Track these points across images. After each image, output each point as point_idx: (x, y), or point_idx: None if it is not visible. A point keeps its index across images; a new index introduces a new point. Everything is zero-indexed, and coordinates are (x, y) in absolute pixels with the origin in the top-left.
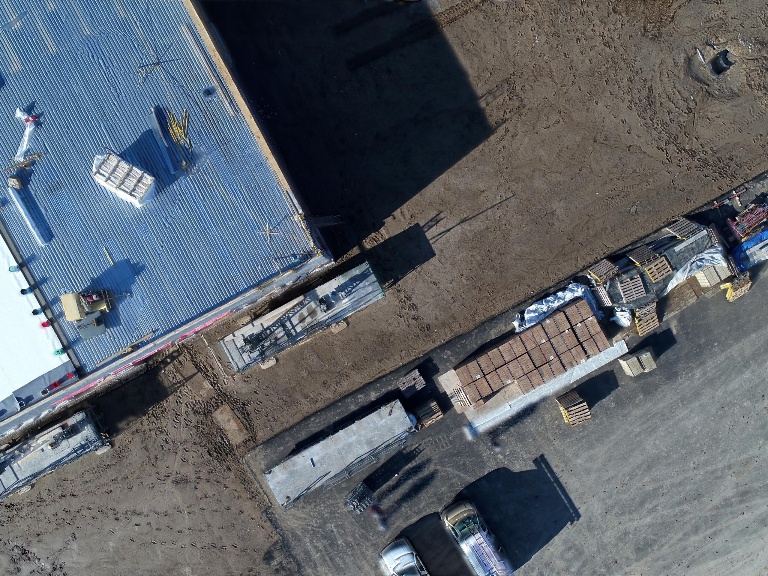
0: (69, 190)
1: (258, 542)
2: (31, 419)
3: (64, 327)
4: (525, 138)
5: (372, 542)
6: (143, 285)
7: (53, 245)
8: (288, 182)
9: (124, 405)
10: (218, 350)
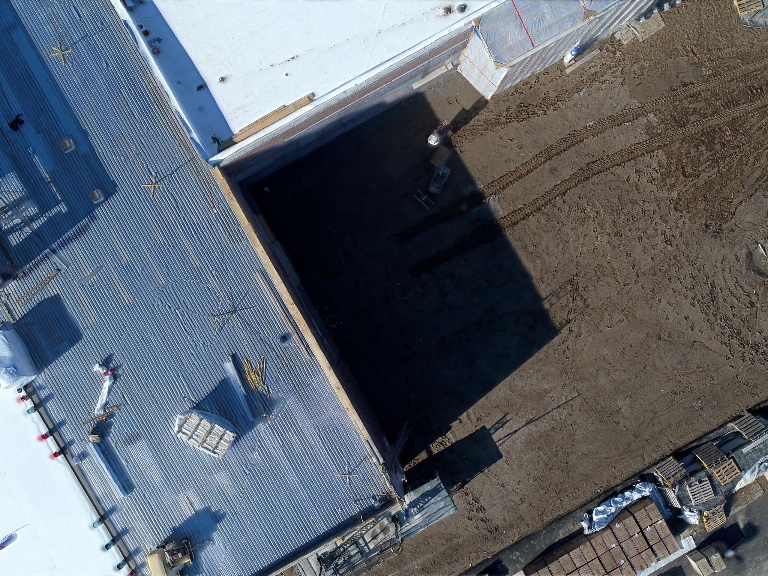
0: (149, 441)
1: None
2: None
3: None
4: (589, 338)
5: None
6: (225, 532)
7: (135, 496)
8: (368, 432)
9: None
10: None
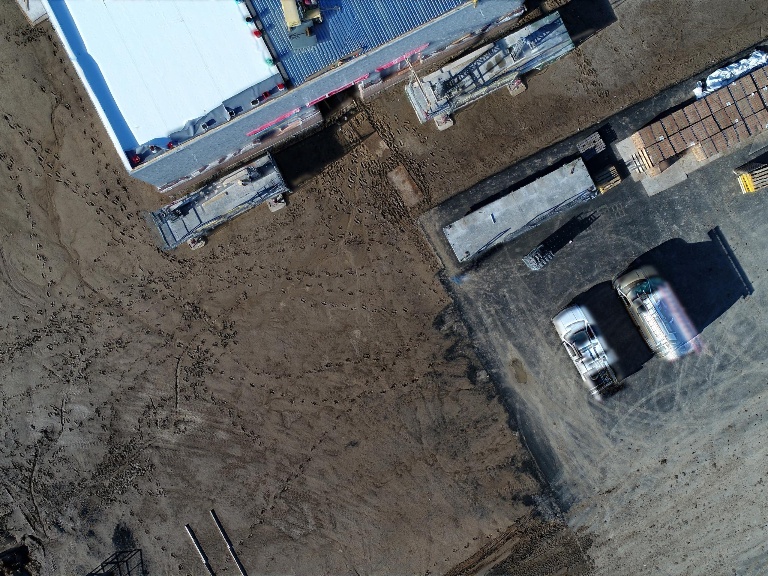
0: None
1: (429, 306)
2: (216, 161)
3: (274, 40)
4: None
5: (544, 308)
6: (353, 0)
7: None
8: None
9: (300, 163)
10: (396, 110)
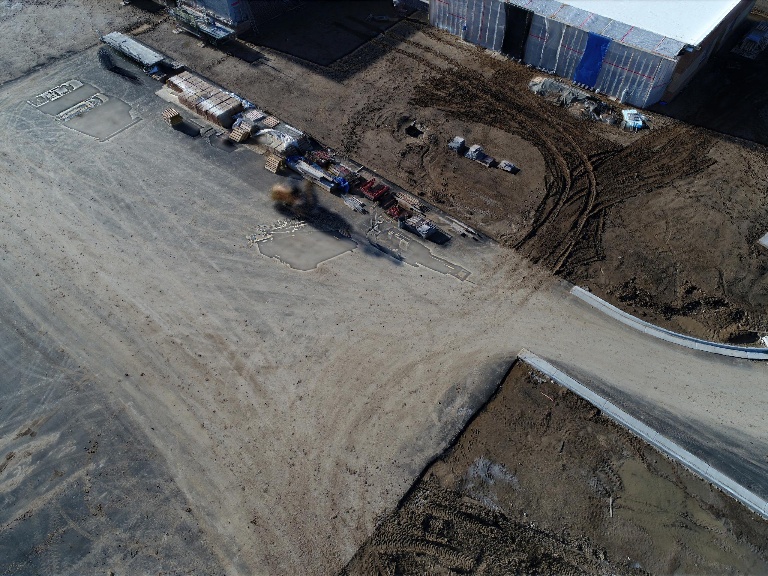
0: None
1: None
2: None
3: None
4: (328, 76)
5: (80, 76)
6: None
7: None
8: None
9: None
10: None
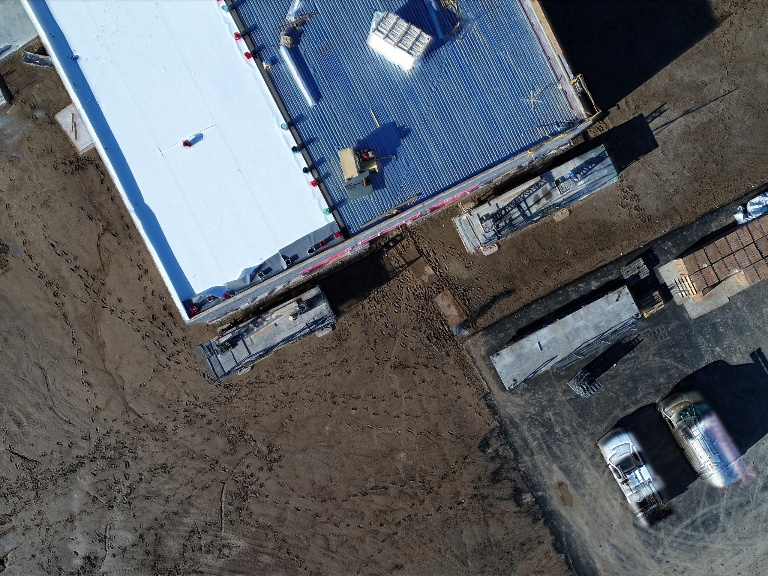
0: (338, 51)
1: (474, 429)
2: (265, 293)
3: (329, 188)
4: (749, 32)
5: (589, 431)
6: (408, 148)
7: (320, 106)
8: None
9: (346, 288)
10: (441, 235)
